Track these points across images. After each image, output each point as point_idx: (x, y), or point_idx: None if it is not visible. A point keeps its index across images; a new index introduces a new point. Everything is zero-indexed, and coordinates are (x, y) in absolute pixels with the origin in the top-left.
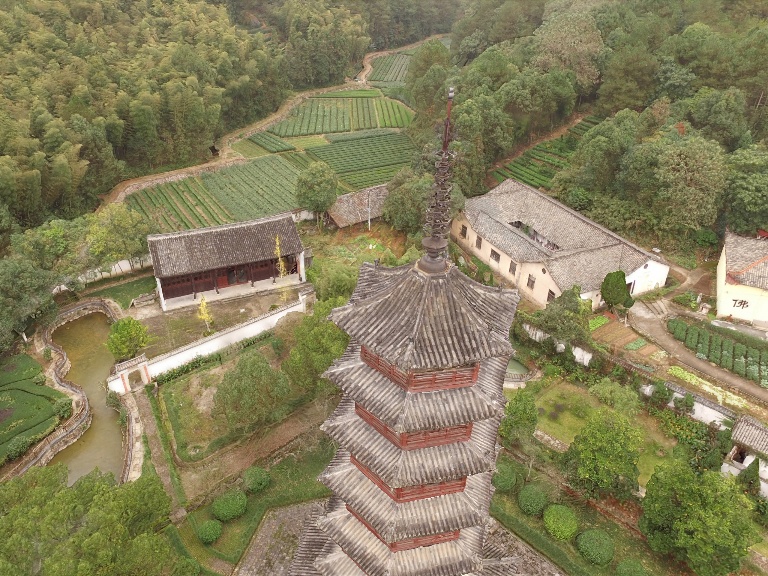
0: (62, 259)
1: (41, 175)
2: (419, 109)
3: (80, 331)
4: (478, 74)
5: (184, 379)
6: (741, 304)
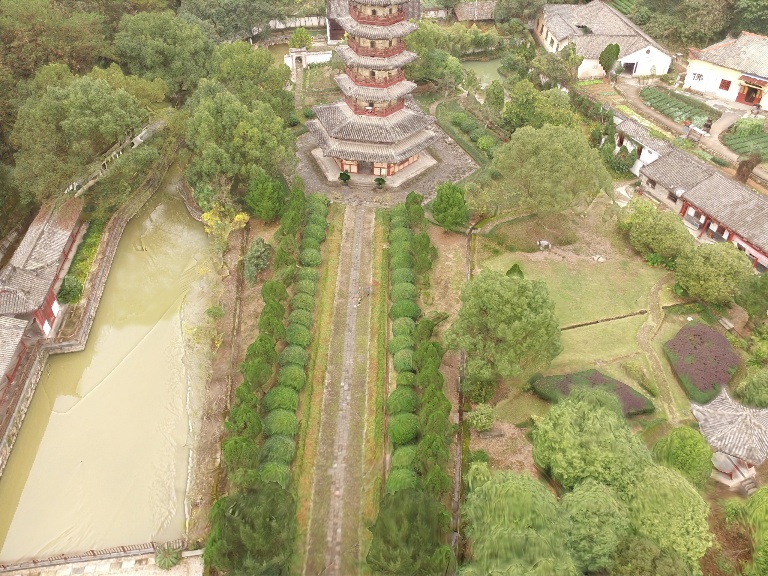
0: (279, 2)
1: None
2: None
3: (281, 48)
4: None
5: None
6: (698, 77)
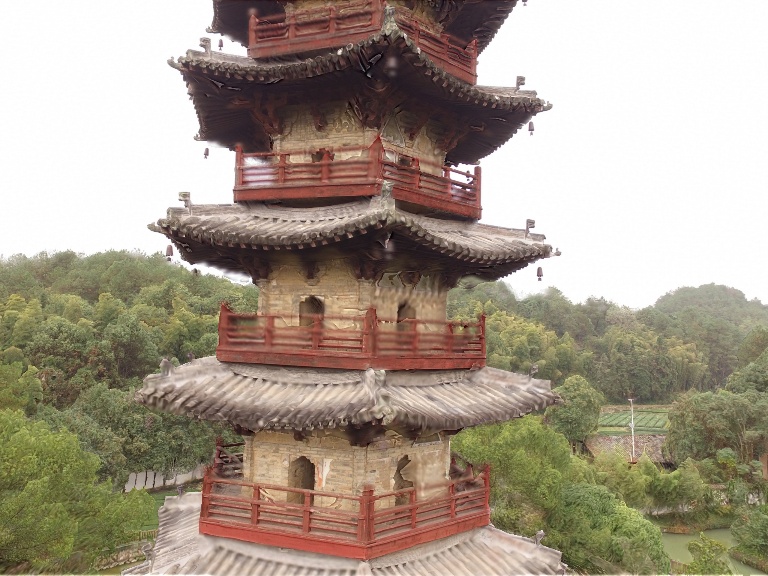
0: None
1: None
2: None
3: None
4: None
5: None
6: None
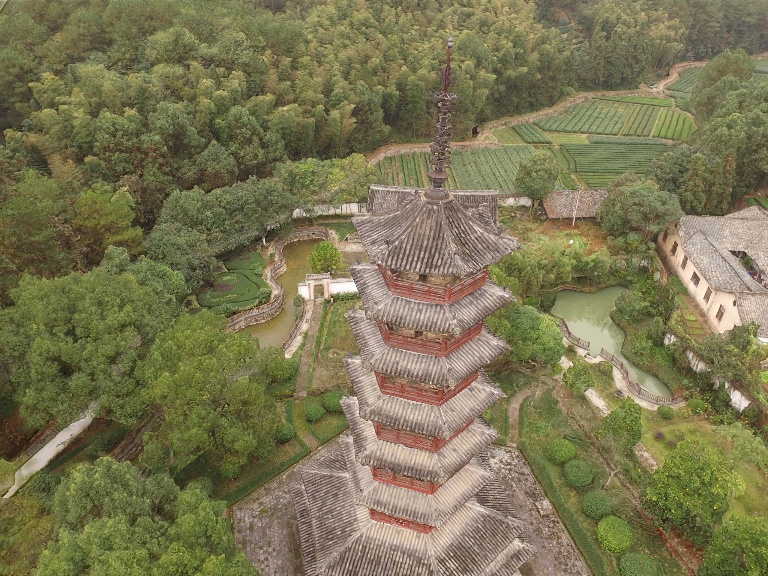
0: (307, 189)
1: (318, 124)
2: (697, 122)
3: (304, 249)
4: (767, 89)
5: (353, 302)
6: None
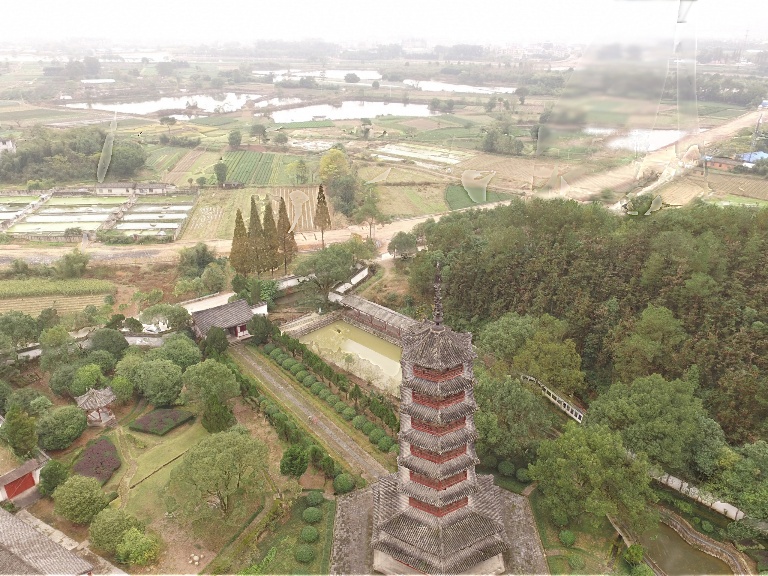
0: None
1: None
2: None
3: None
4: None
5: None
6: None
